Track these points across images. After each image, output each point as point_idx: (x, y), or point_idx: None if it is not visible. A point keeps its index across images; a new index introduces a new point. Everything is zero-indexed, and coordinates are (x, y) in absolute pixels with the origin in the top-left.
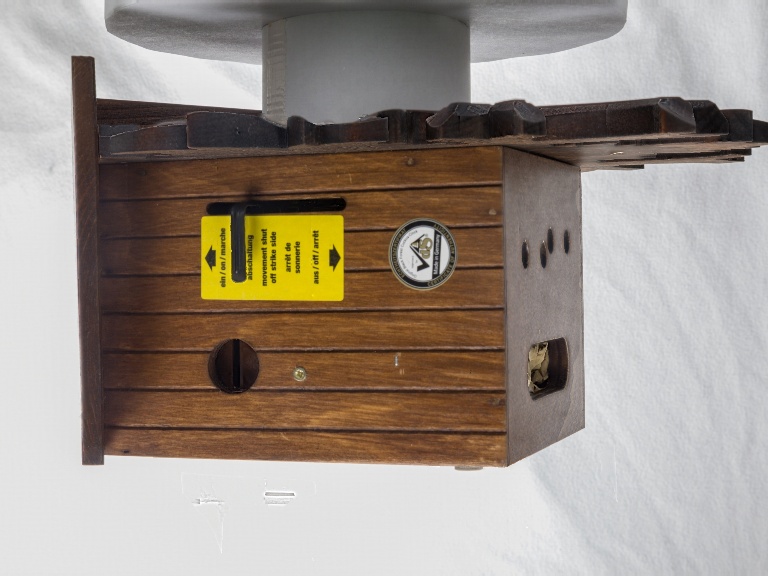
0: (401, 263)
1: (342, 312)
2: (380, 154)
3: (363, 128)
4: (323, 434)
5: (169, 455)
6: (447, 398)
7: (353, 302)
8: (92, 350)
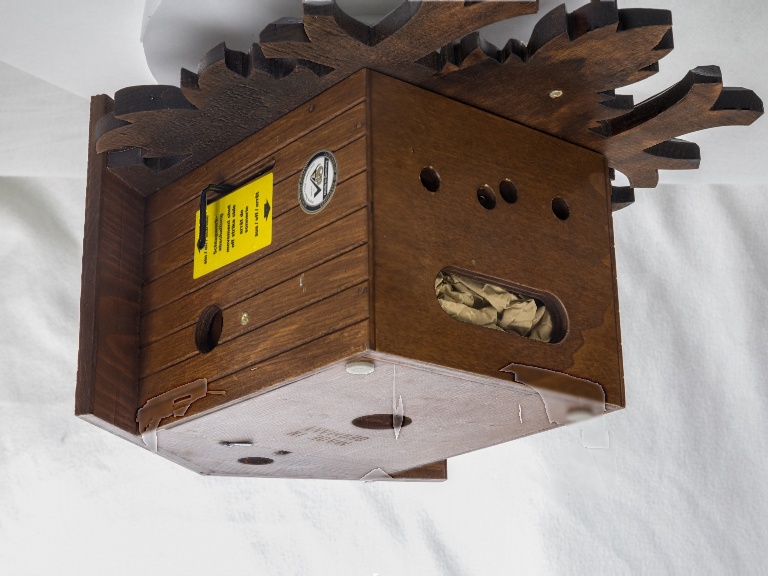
0: (305, 195)
1: (271, 254)
2: (294, 111)
3: (209, 55)
4: (257, 366)
5: (171, 421)
6: (331, 301)
7: (277, 242)
8: (88, 319)
